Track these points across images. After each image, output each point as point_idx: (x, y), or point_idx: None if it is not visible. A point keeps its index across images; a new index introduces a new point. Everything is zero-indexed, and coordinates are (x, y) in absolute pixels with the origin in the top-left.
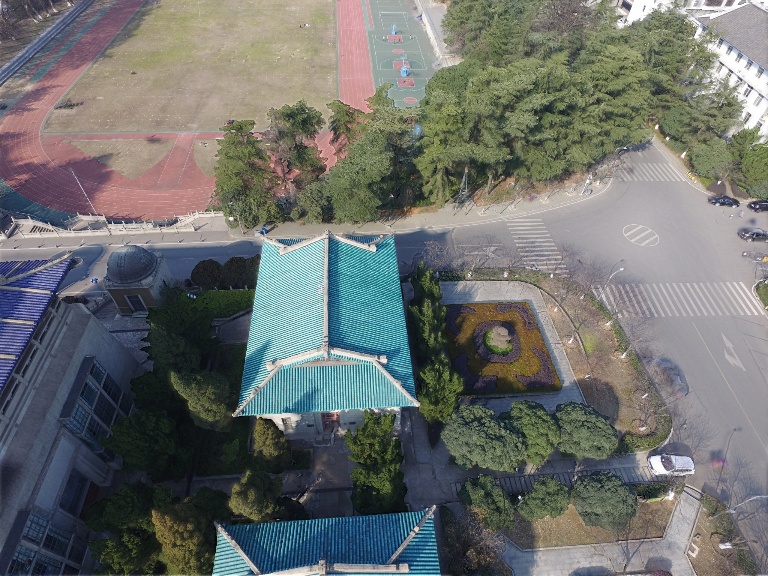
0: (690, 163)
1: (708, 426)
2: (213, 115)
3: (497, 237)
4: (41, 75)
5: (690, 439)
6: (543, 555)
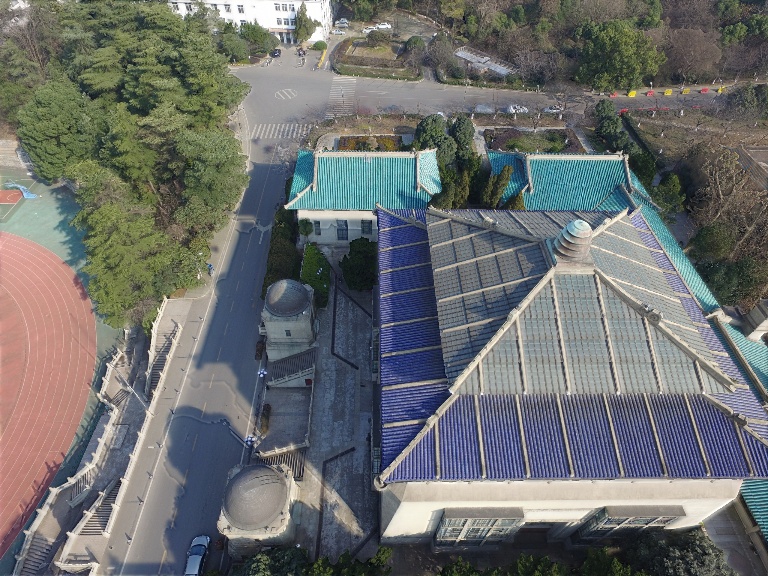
0: None
1: (419, 108)
2: None
3: (268, 144)
4: None
5: (426, 114)
6: None
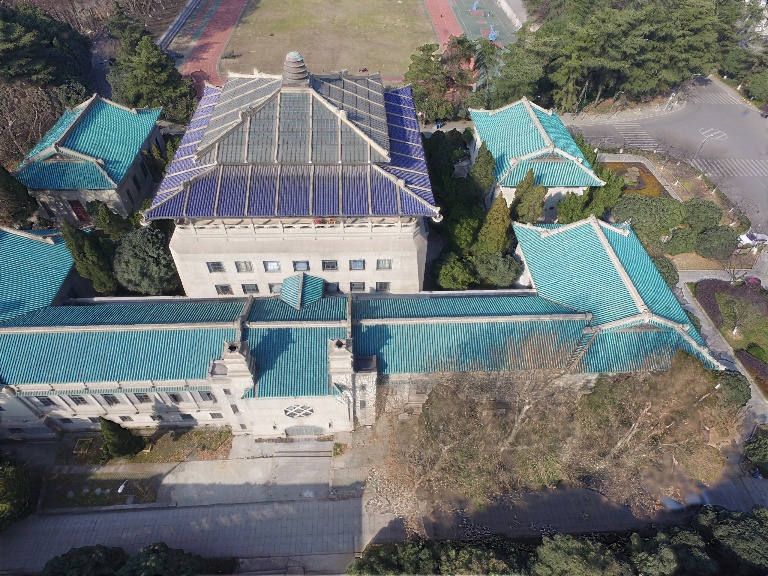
0: (745, 93)
1: None
2: (348, 65)
3: (608, 132)
4: (199, 35)
5: (763, 232)
6: (680, 273)
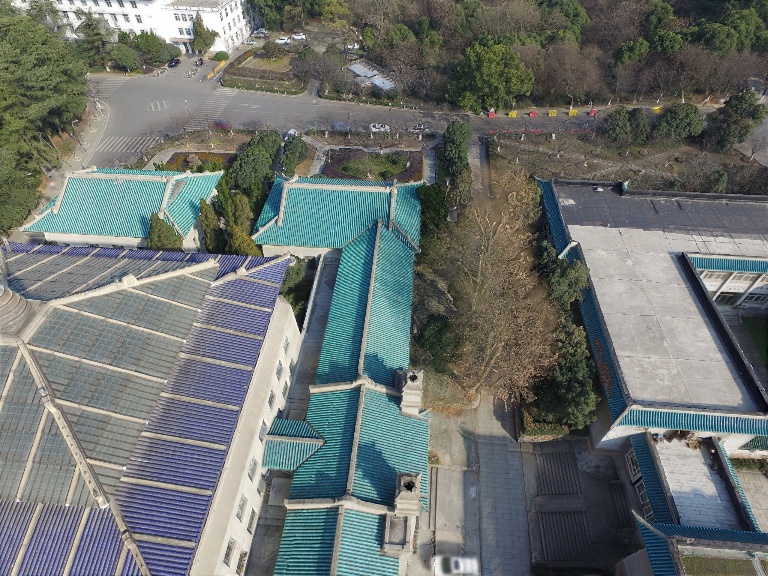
0: (118, 70)
1: (281, 124)
2: None
3: (108, 158)
4: None
5: (283, 130)
6: None
